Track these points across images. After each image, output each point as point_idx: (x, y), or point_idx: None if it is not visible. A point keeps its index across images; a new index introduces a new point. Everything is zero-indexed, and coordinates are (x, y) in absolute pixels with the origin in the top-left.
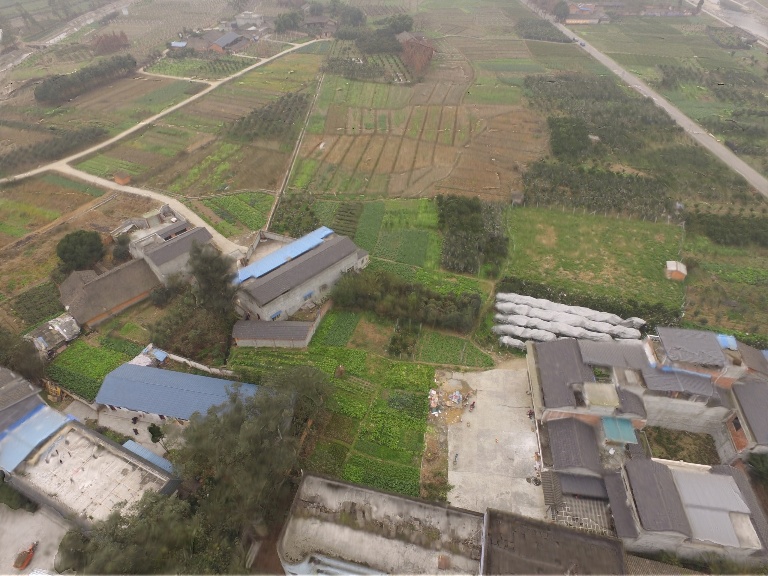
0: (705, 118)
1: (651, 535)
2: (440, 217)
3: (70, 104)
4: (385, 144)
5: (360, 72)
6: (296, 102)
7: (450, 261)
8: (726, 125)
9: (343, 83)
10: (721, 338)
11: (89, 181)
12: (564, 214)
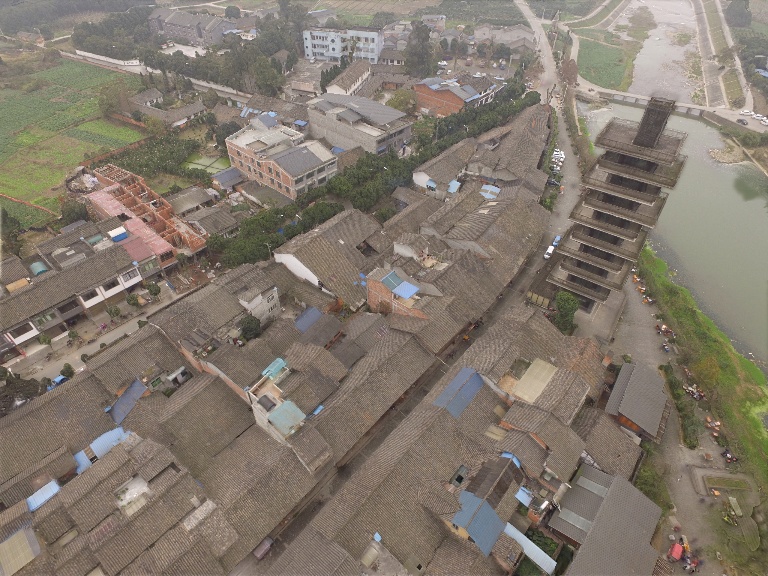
0: None
1: None
2: (375, 16)
3: None
4: (361, 3)
5: None
6: None
7: (373, 23)
8: None
9: None
10: None
11: (224, 8)
12: None
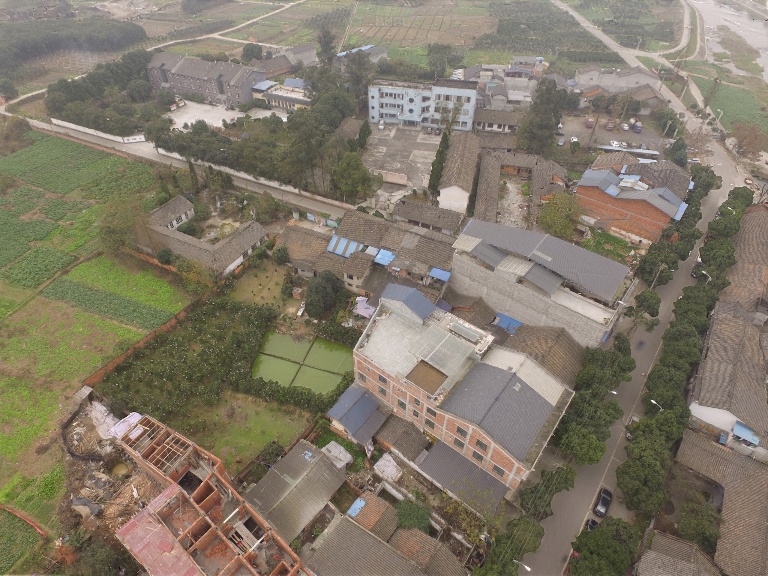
0: (595, 19)
1: (495, 101)
2: (429, 50)
3: (202, 13)
4: (399, 30)
5: (382, 0)
6: (343, 13)
7: (432, 61)
8: (607, 22)
9: (371, 6)
10: (538, 58)
11: (234, 41)
12: (496, 52)
